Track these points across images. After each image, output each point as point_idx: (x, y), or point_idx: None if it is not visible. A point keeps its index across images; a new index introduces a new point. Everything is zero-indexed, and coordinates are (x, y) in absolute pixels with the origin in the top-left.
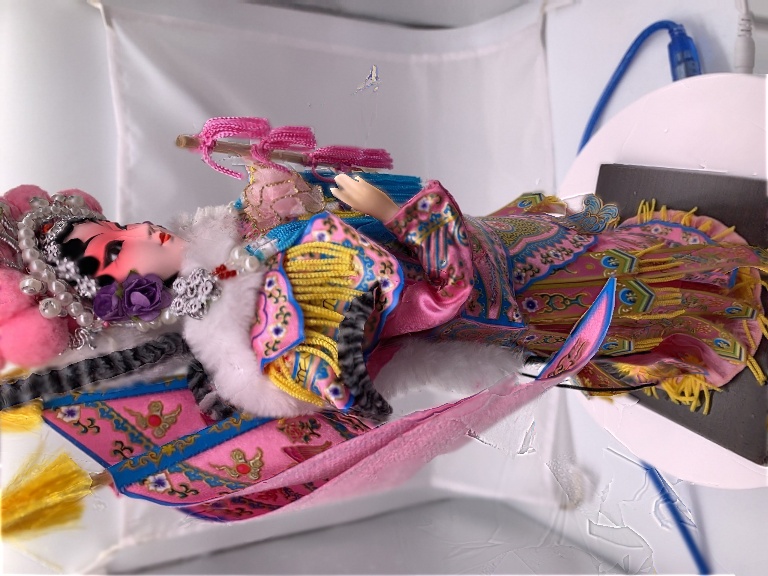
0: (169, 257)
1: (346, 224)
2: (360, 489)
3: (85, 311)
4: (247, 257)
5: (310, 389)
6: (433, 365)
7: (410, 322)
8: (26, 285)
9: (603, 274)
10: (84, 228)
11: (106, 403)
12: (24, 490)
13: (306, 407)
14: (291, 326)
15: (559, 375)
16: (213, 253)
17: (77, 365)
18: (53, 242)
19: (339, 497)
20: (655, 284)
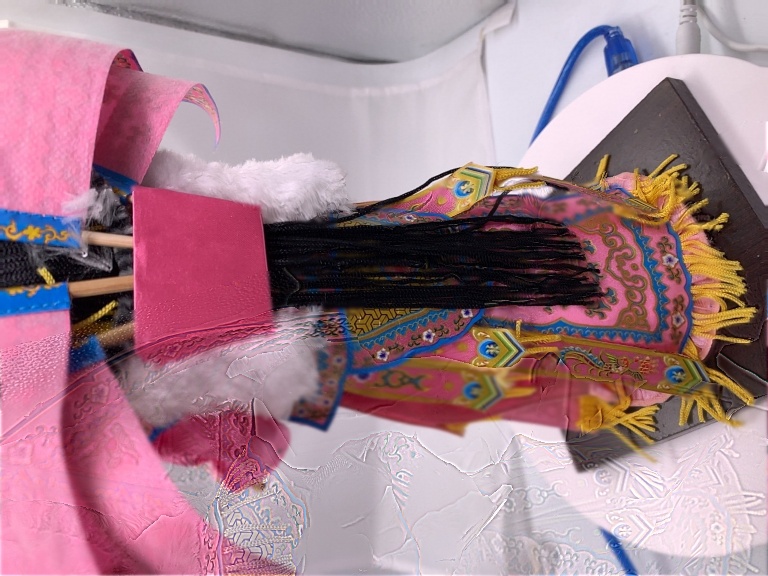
0: None
1: None
2: None
3: None
4: None
5: None
6: None
7: None
8: None
9: None
10: None
11: None
12: None
13: None
14: None
15: None
16: None
17: None
18: None
19: None
20: None
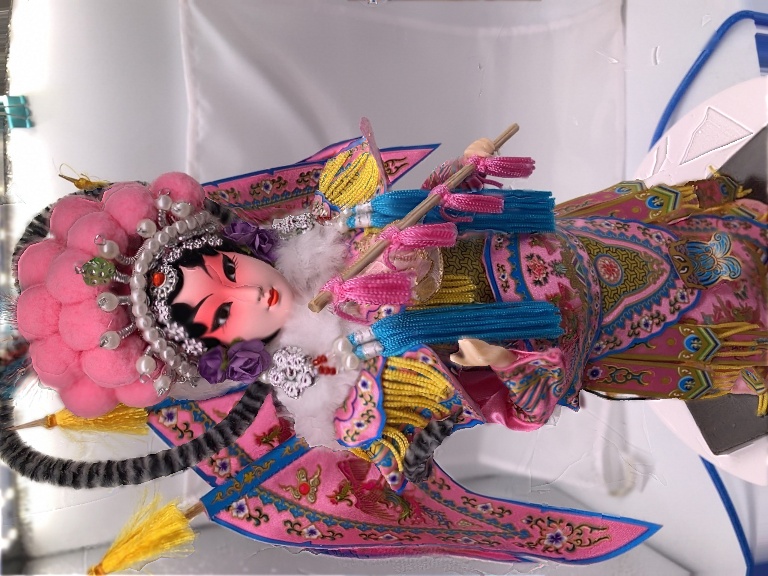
0: (274, 322)
1: (453, 378)
2: (390, 575)
3: (191, 366)
4: (349, 355)
5: None
6: None
7: None
8: (142, 368)
9: (679, 355)
10: (194, 281)
11: (198, 405)
12: (145, 542)
13: None
14: (372, 425)
15: (573, 564)
16: (318, 341)
17: (187, 452)
18: (164, 301)
19: (373, 574)
20: (720, 370)
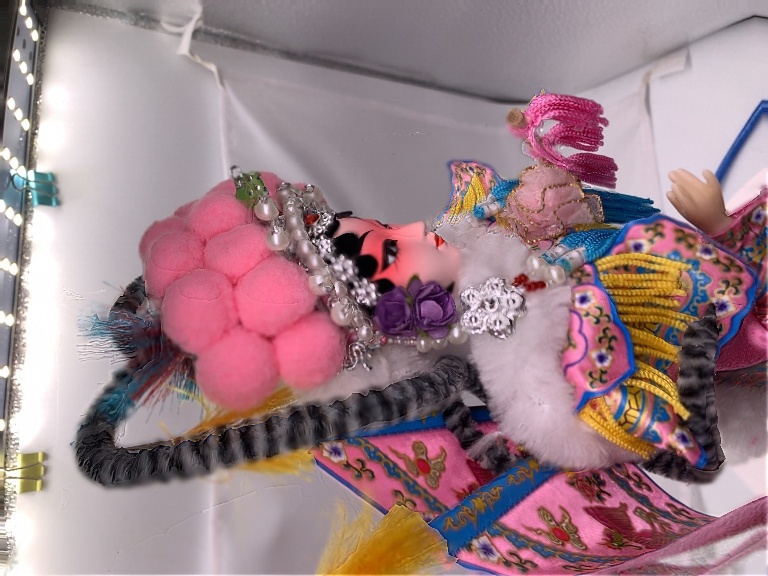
0: (447, 263)
1: None
2: None
3: (365, 321)
4: (550, 267)
5: (641, 434)
6: (723, 414)
7: (734, 357)
8: (318, 282)
9: None
10: (350, 223)
11: (368, 440)
12: (372, 553)
13: (618, 457)
14: (618, 353)
15: None
16: (508, 260)
17: (400, 386)
18: (323, 236)
19: None
20: None
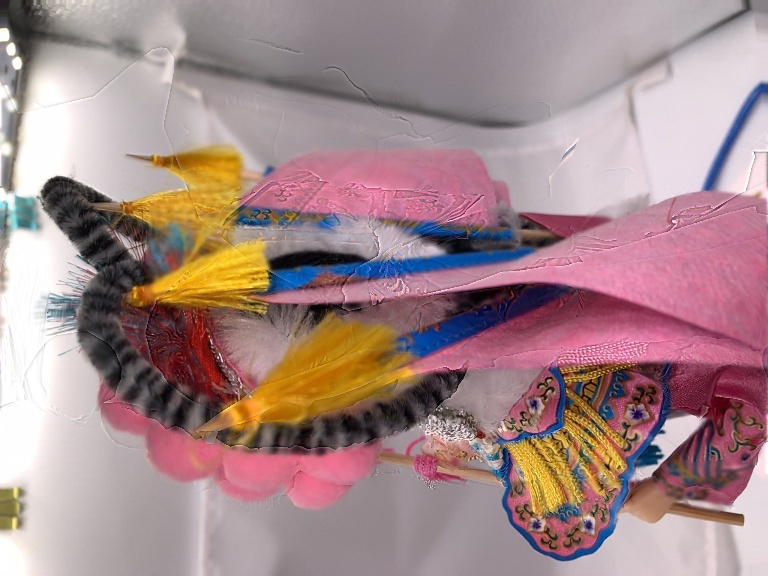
0: None
1: None
2: None
3: None
4: None
5: None
6: (519, 259)
7: None
8: None
9: None
10: None
11: (287, 229)
12: None
13: None
14: None
15: None
16: None
17: None
18: None
19: None
20: None
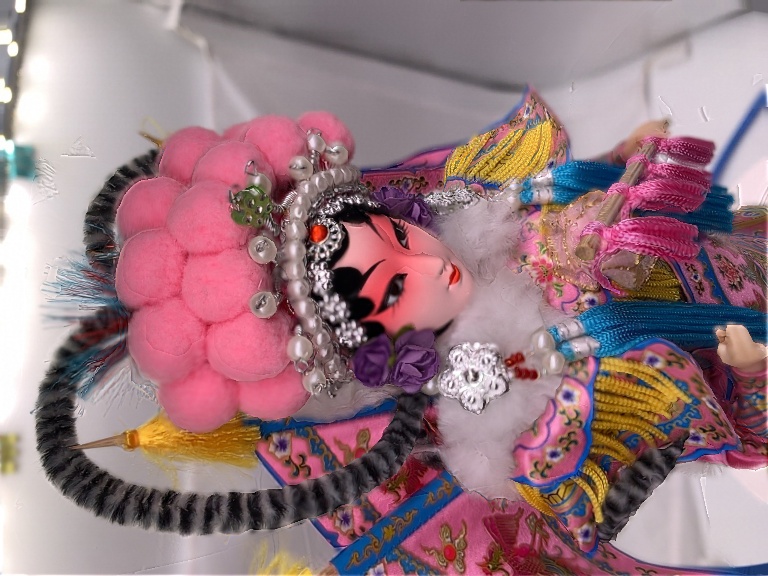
0: (452, 307)
1: None
2: None
3: (341, 363)
4: (553, 353)
5: (555, 512)
6: None
7: None
8: (297, 352)
9: None
10: (361, 241)
11: (317, 431)
12: None
13: None
14: (572, 455)
15: None
16: (514, 333)
17: (344, 481)
18: (324, 263)
19: None
20: None
